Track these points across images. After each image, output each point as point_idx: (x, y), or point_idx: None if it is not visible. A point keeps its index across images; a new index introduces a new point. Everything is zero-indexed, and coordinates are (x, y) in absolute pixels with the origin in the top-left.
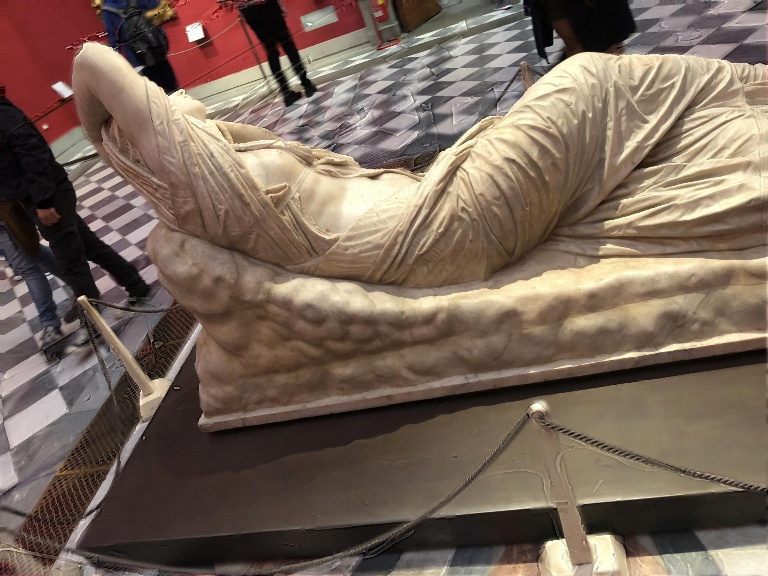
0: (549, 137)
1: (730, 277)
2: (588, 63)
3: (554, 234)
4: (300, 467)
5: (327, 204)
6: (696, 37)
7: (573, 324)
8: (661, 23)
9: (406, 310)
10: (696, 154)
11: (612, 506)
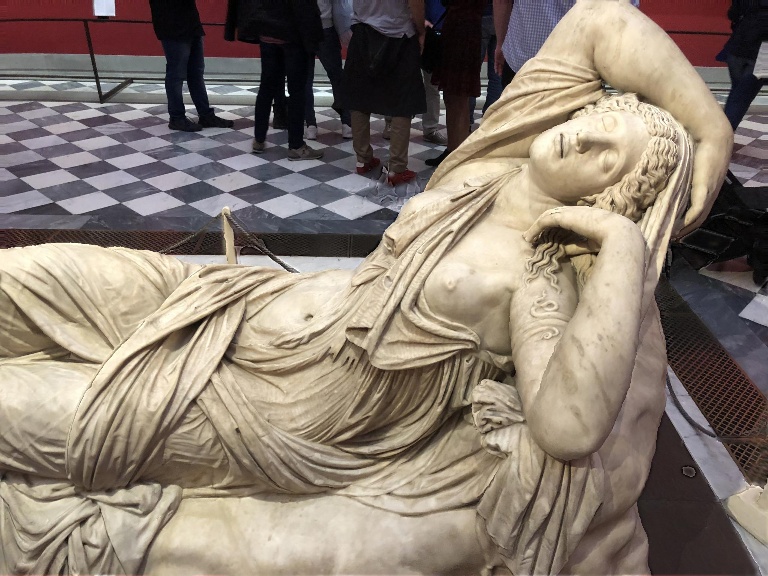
0: None
1: None
2: None
3: None
4: None
5: None
6: None
7: None
8: None
9: None
10: None
11: None
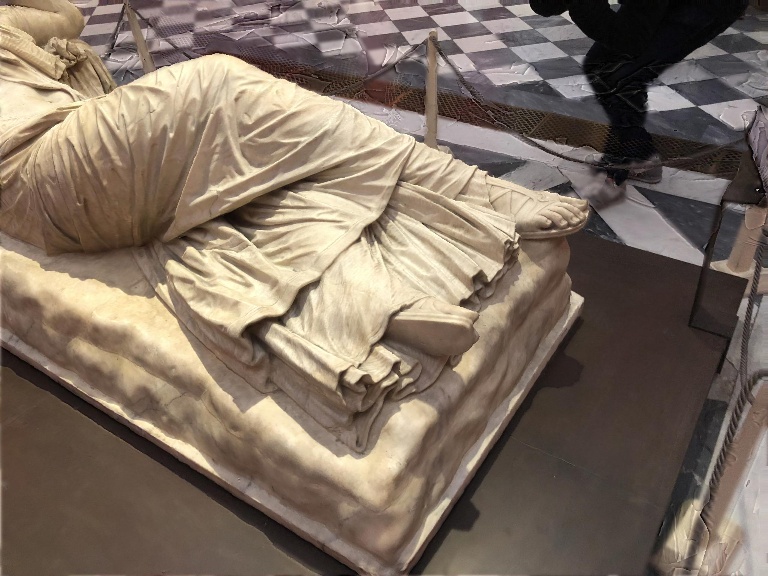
0: (115, 138)
1: (202, 392)
2: (209, 71)
3: (152, 243)
4: None
5: None
6: (766, 88)
7: (77, 346)
8: (759, 51)
9: None
10: (273, 239)
11: None
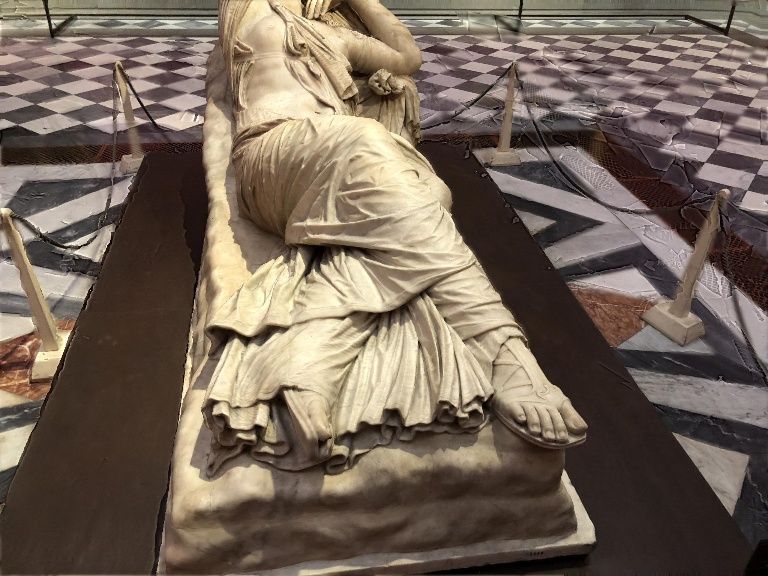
0: None
1: None
2: (350, 130)
3: None
4: (172, 213)
5: (262, 85)
6: None
7: None
8: None
9: (210, 181)
10: None
11: (67, 345)
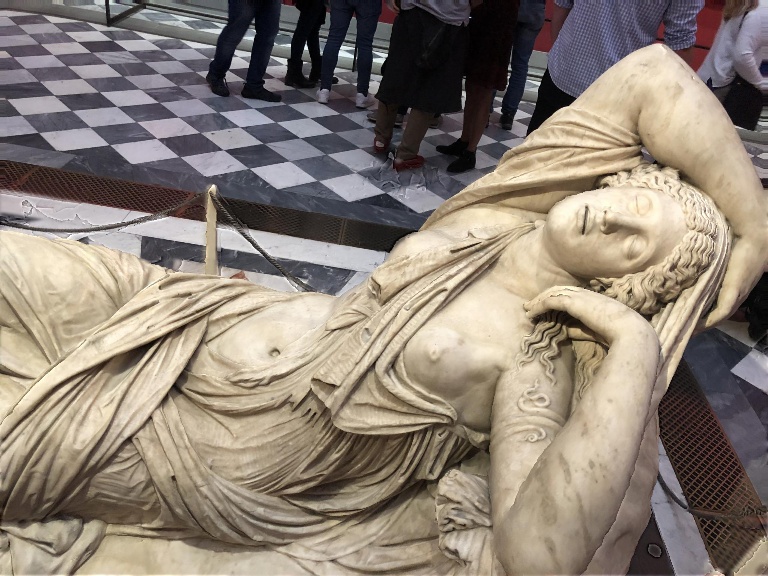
0: None
1: None
2: None
3: None
4: None
5: None
6: None
7: None
8: None
9: None
10: None
11: None
